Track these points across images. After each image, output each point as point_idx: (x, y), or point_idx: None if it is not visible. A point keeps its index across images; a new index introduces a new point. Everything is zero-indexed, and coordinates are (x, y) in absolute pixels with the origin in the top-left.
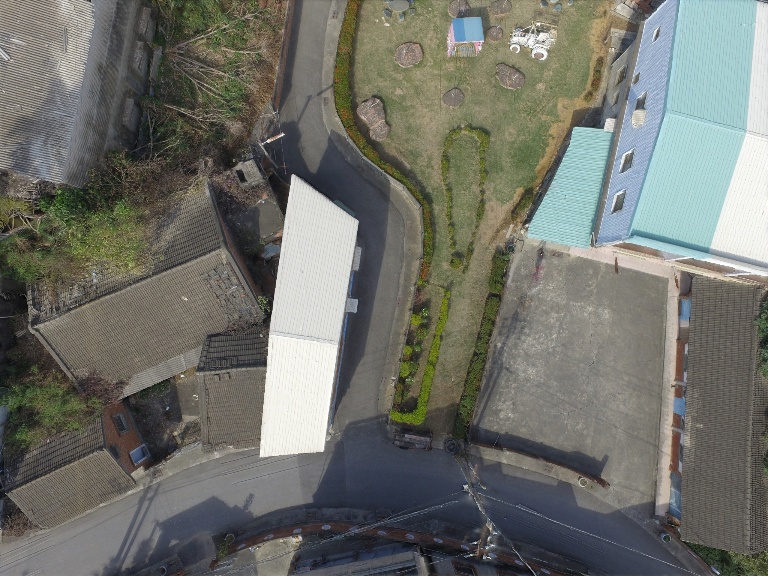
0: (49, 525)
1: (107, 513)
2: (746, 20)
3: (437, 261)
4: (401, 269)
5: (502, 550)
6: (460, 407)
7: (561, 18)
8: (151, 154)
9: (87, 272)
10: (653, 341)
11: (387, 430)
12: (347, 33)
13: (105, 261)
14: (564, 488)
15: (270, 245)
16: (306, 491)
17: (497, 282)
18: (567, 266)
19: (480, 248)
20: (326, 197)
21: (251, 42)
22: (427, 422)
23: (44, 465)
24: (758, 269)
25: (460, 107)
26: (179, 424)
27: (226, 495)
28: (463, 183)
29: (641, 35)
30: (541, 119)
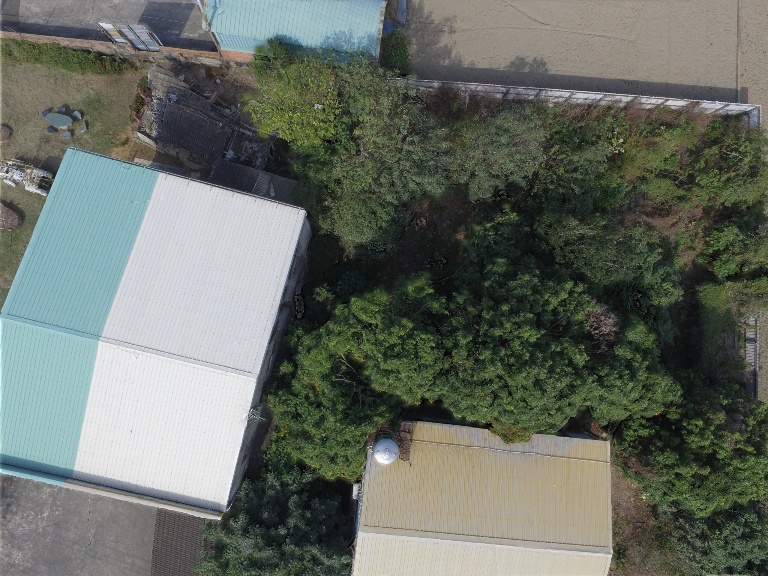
0: None
1: None
2: (141, 196)
3: None
4: None
5: None
6: None
7: None
8: None
9: None
10: None
11: None
12: None
13: None
14: None
15: None
16: None
17: None
18: None
19: None
20: None
21: None
22: None
23: None
24: None
25: None
26: None
27: None
28: None
29: None
30: None
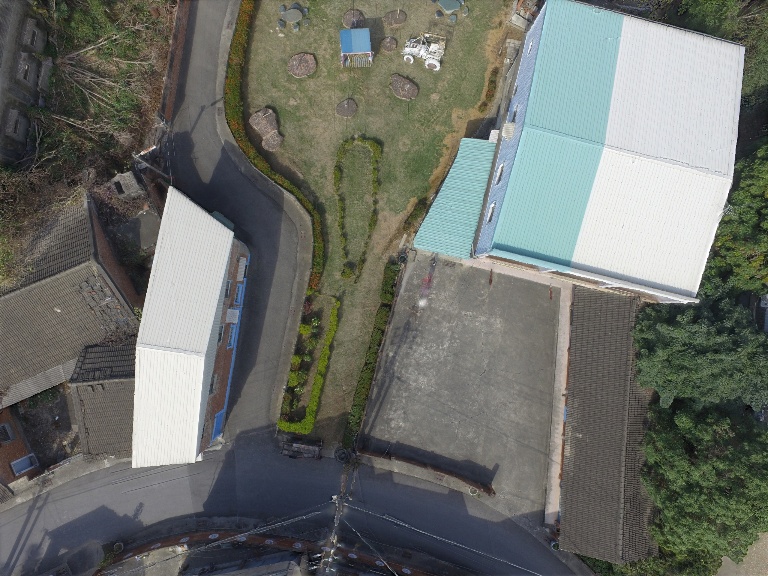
0: None
1: None
2: (612, 34)
3: (329, 271)
4: (294, 279)
5: (393, 558)
6: (349, 416)
7: (456, 29)
8: (32, 165)
9: None
10: (545, 350)
11: (278, 439)
12: (238, 44)
13: None
14: (455, 496)
15: None
16: (196, 500)
17: (387, 292)
18: (459, 276)
19: (373, 258)
20: (202, 209)
21: (144, 52)
22: (318, 431)
23: None
24: (616, 282)
25: (354, 117)
26: (69, 433)
27: (116, 504)
28: (356, 193)
29: (523, 47)
30: (435, 129)
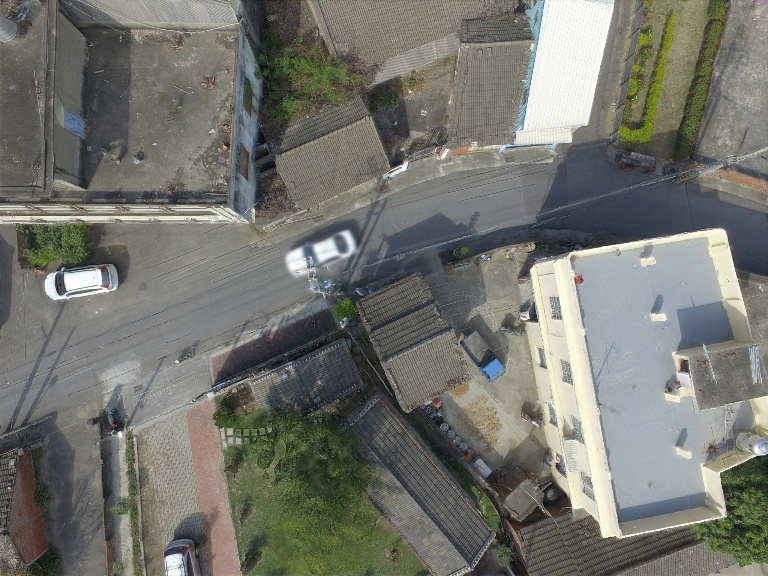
0: (305, 204)
1: (335, 226)
2: None
3: None
4: None
5: None
6: (685, 127)
7: None
8: None
9: None
10: None
11: (608, 155)
12: None
13: None
14: None
15: None
16: (530, 211)
17: (720, 7)
18: None
19: None
20: None
21: None
22: (648, 146)
23: (309, 134)
24: None
25: None
26: (406, 140)
27: (452, 212)
28: None
29: None
30: None
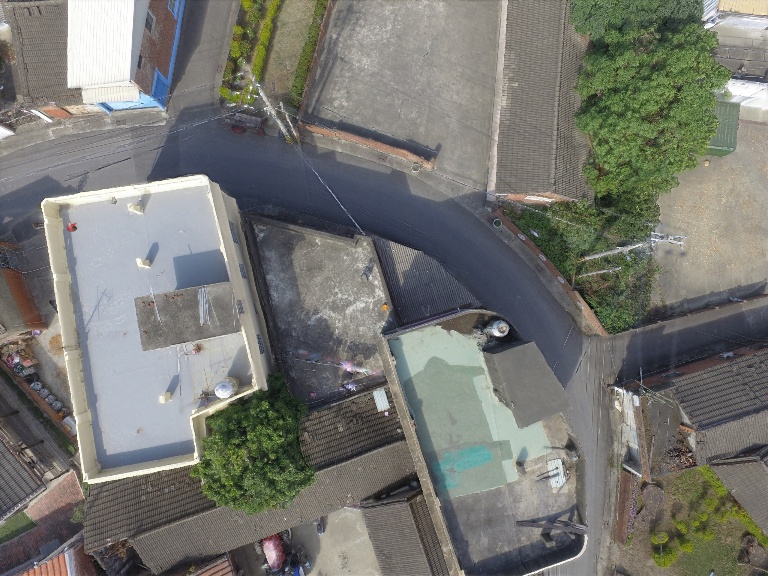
0: None
1: None
2: None
3: None
4: None
5: None
6: (291, 88)
7: None
8: None
9: None
10: (488, 35)
11: None
12: None
13: None
14: (398, 176)
15: None
16: (140, 173)
17: None
18: None
19: None
20: None
21: None
22: (261, 108)
23: None
24: None
25: None
26: (14, 104)
27: (60, 175)
28: None
29: None
30: None
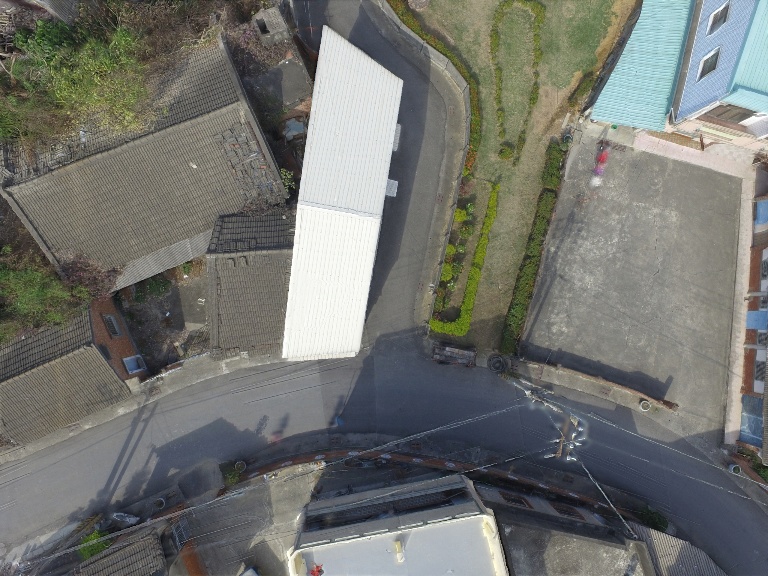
0: (24, 440)
1: (94, 436)
2: None
3: (483, 152)
4: (442, 161)
5: (552, 482)
6: (509, 317)
7: None
8: (152, 1)
9: (73, 130)
10: (724, 249)
11: (424, 345)
12: None
13: (95, 119)
14: (623, 413)
15: (292, 121)
16: (330, 413)
17: (553, 175)
18: (630, 162)
19: (532, 139)
20: None
21: None
22: (470, 335)
23: (18, 364)
24: None
25: None
26: (181, 333)
27: (236, 416)
28: (514, 63)
29: None
30: None
